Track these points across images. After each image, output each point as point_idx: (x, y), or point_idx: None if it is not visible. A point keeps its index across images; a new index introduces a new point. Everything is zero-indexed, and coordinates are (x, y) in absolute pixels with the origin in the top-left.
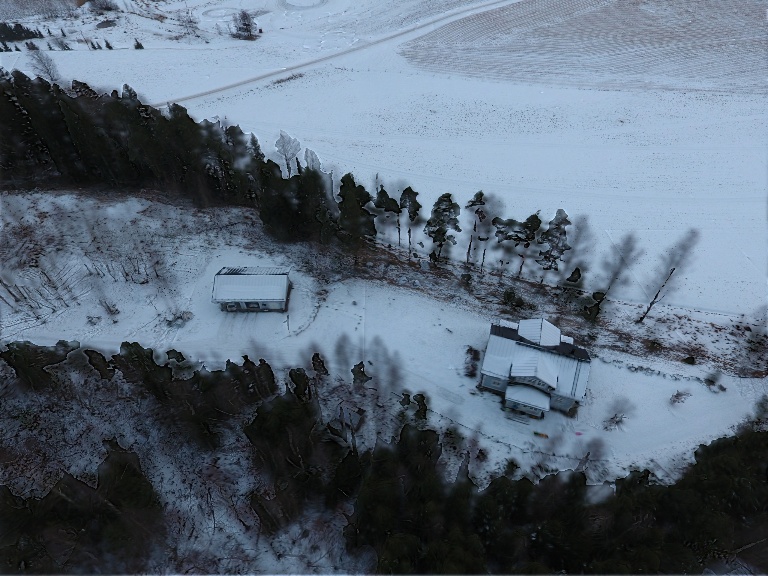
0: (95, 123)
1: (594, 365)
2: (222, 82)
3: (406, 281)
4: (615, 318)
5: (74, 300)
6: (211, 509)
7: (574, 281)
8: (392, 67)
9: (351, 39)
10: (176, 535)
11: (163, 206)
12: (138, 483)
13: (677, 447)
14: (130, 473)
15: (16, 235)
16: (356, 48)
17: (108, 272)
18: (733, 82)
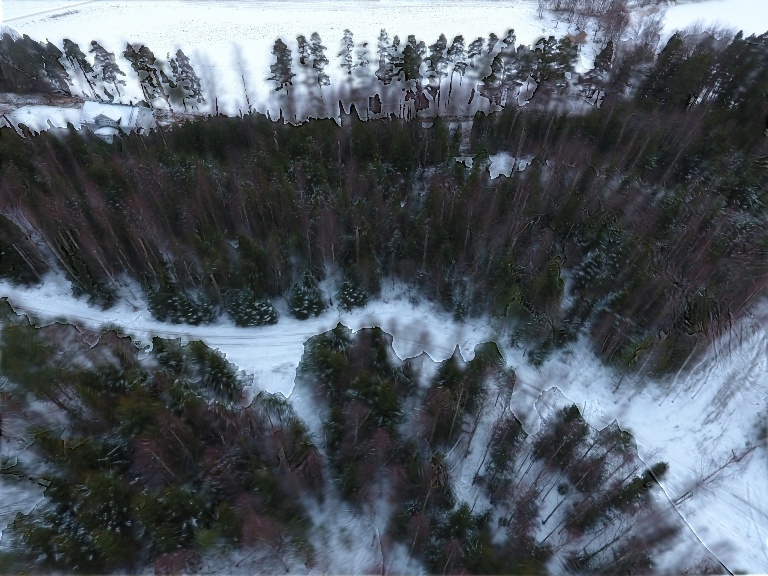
0: None
1: None
2: (1, 18)
3: None
4: None
5: None
6: None
7: None
8: (162, 3)
9: None
10: None
11: None
12: None
13: None
14: None
15: None
16: None
17: None
18: (436, 0)
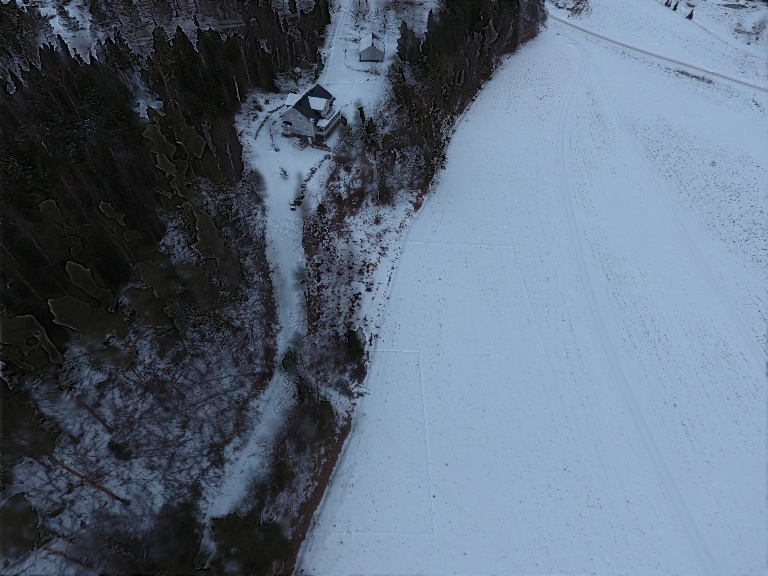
0: None
1: (318, 156)
2: (654, 50)
3: (398, 107)
4: (383, 212)
5: (368, 21)
6: None
7: None
8: None
9: None
10: None
11: None
12: None
13: (255, 165)
14: None
15: (406, 2)
16: None
17: None
18: None
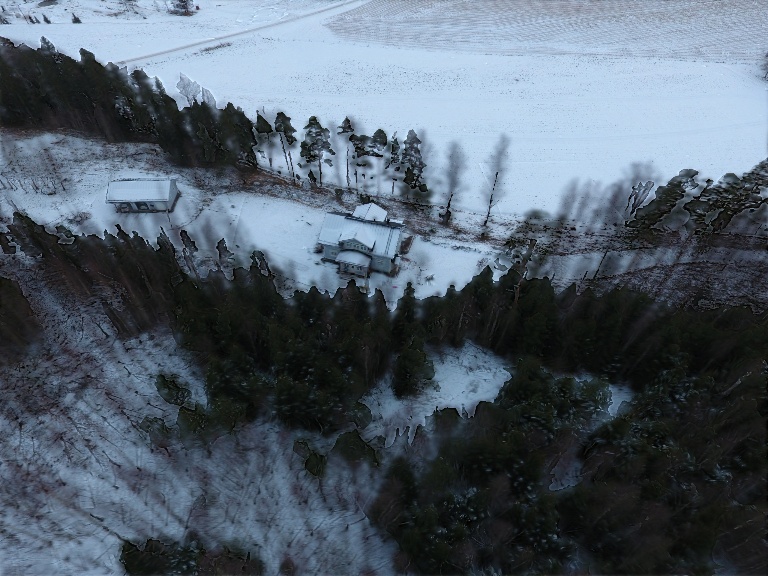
0: (11, 66)
1: (425, 246)
2: (153, 50)
3: (286, 195)
4: (466, 224)
5: None
6: (82, 328)
7: (410, 180)
8: (316, 37)
9: (281, 13)
10: (51, 342)
11: (76, 139)
12: (13, 292)
13: None
14: (6, 284)
15: None
16: (284, 21)
17: (21, 187)
18: (625, 47)
